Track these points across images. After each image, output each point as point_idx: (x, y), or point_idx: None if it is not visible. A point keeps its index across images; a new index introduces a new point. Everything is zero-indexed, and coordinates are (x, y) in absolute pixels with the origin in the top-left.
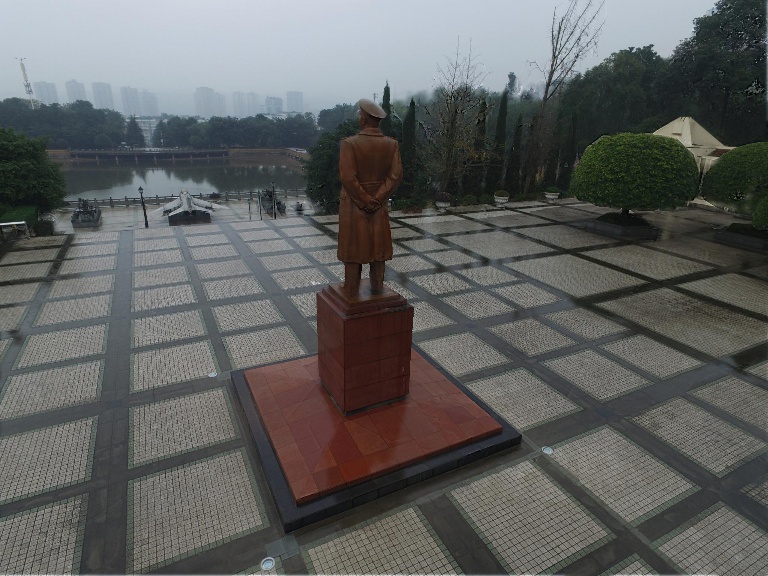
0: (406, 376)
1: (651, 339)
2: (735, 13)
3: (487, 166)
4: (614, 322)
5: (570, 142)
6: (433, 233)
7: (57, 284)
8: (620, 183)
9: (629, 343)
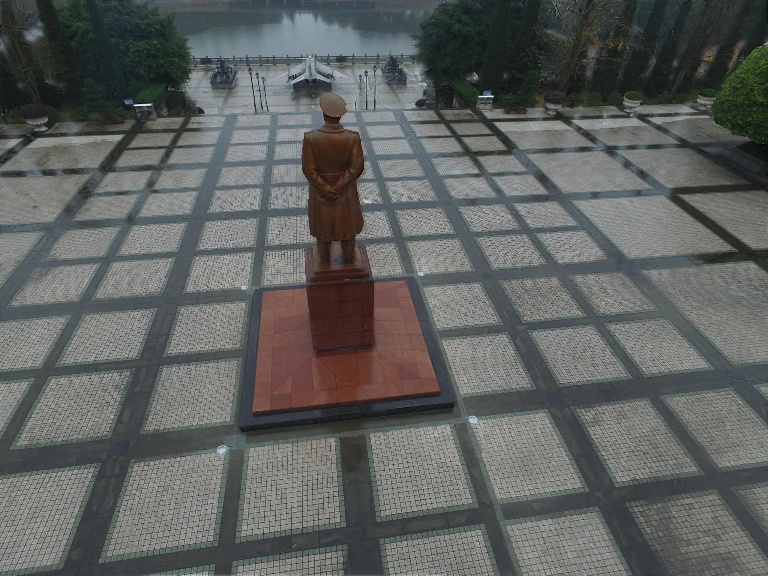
0: (370, 331)
1: (673, 327)
2: None
3: (624, 58)
4: (647, 298)
5: (753, 28)
6: (520, 147)
7: (163, 174)
8: None
9: (643, 327)
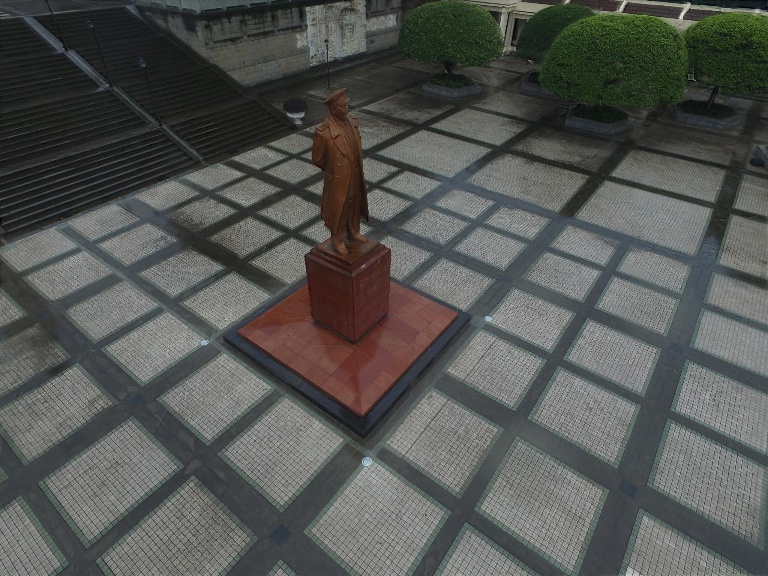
0: None
1: None
2: None
3: None
4: None
5: None
6: None
7: None
8: None
9: None
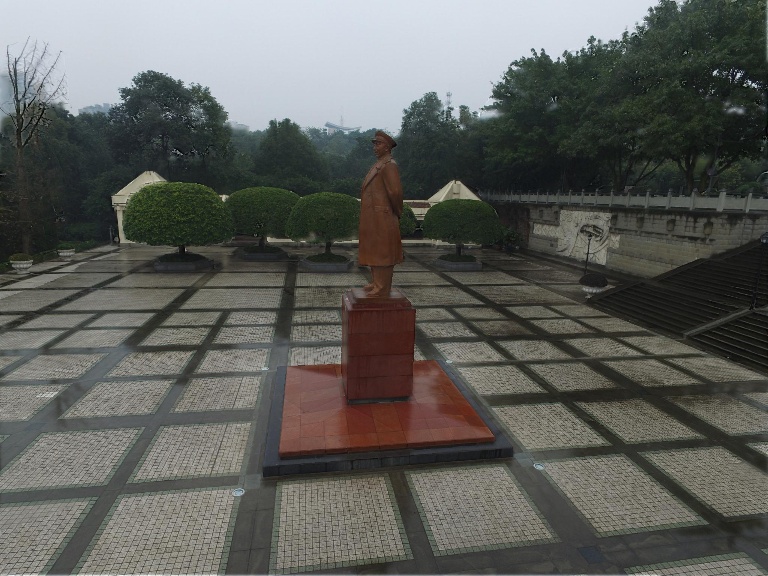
0: None
1: None
2: (158, 91)
3: None
4: (325, 310)
5: (68, 194)
6: (30, 310)
7: None
8: (193, 223)
9: None
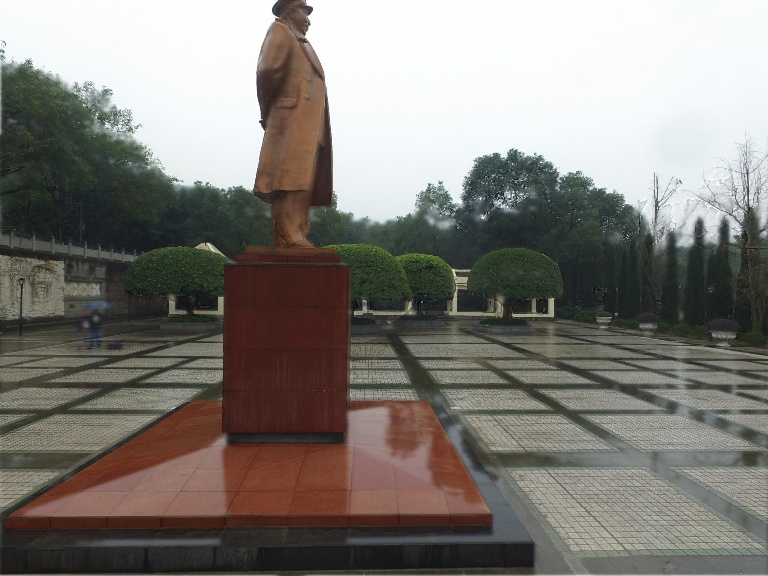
0: None
1: None
2: None
3: None
4: None
5: None
6: None
7: (711, 372)
8: None
9: None
